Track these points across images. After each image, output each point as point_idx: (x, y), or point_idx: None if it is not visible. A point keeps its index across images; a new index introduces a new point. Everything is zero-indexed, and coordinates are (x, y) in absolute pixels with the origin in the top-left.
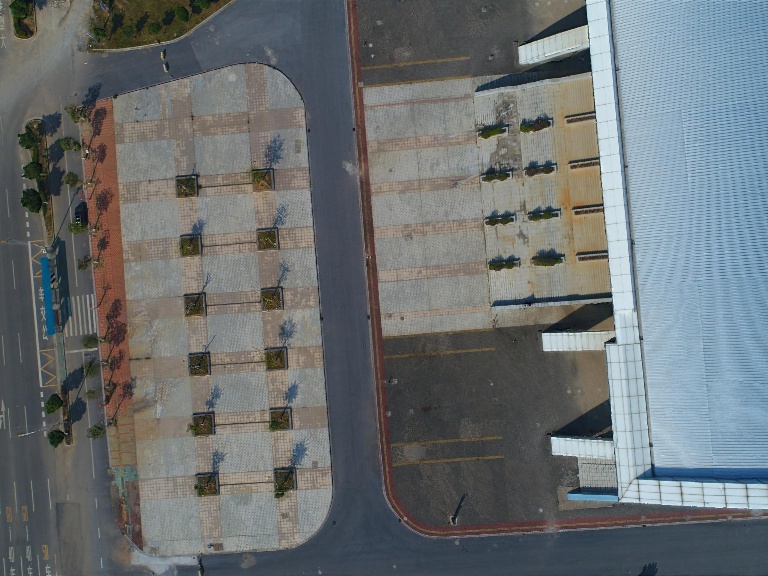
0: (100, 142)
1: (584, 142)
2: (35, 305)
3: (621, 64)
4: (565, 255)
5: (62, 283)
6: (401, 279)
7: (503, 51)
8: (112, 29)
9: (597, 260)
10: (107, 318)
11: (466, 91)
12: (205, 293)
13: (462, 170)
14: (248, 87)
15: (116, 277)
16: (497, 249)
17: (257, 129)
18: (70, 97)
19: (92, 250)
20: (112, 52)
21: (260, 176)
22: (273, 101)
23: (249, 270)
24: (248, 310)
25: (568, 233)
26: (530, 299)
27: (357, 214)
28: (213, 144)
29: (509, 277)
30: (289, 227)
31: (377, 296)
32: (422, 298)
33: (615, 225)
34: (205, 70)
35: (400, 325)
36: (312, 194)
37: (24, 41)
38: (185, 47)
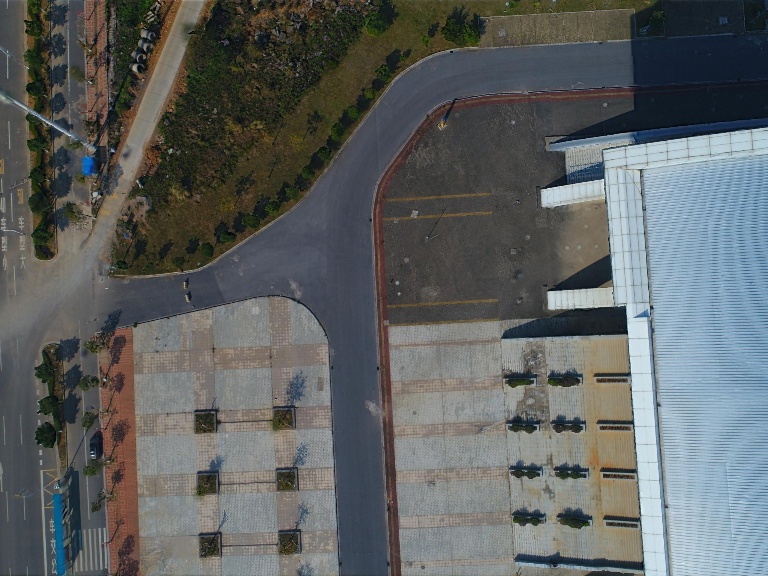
0: (118, 371)
1: (614, 403)
2: (45, 537)
3: (663, 402)
4: (592, 517)
5: (74, 515)
6: (423, 526)
7: (532, 295)
8: (134, 255)
9: (626, 527)
10: (119, 554)
11: (493, 334)
12: (221, 533)
13: (488, 416)
14: (271, 321)
15: (130, 512)
16: (522, 501)
17: (279, 365)
18: (89, 322)
19: (106, 482)
20: (134, 278)
21: (281, 414)
22: (296, 336)
23: (267, 511)
24: (265, 552)
25: (596, 494)
26: (555, 557)
27: (379, 456)
28: (234, 378)
29: (534, 532)
30: (309, 467)
31: (398, 543)
32: (444, 547)
33: (655, 572)
34: (228, 301)
35: (421, 574)
36: (334, 434)
37: (44, 262)
38: (208, 277)
